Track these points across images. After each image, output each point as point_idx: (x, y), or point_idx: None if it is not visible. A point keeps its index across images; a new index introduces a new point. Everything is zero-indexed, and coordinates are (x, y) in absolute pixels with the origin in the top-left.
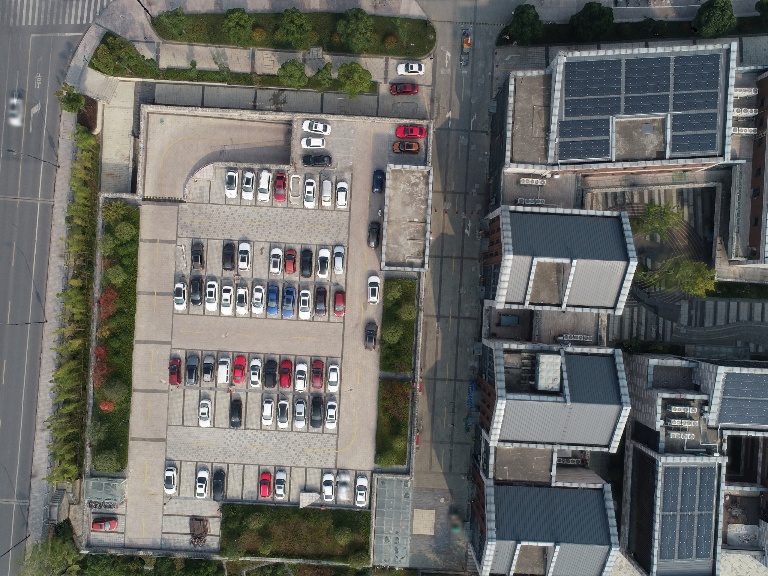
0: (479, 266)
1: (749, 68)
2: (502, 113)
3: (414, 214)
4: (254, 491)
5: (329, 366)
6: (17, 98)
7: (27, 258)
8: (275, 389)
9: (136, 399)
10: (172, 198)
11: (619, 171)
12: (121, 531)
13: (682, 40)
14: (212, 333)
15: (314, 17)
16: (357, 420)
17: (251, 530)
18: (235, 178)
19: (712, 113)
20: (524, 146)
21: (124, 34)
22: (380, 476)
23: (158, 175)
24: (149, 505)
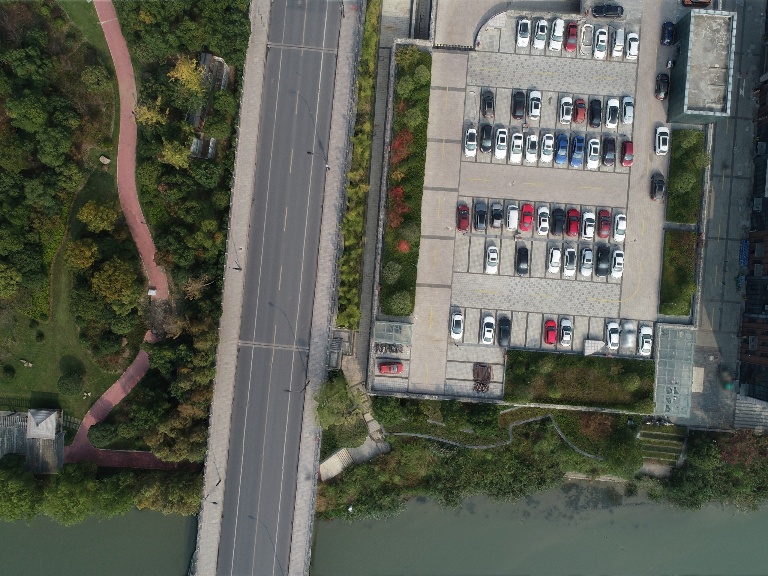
0: (753, 126)
1: None
2: None
3: (715, 60)
4: (537, 339)
5: (616, 215)
6: None
7: (310, 107)
8: (560, 238)
9: (422, 245)
10: (462, 46)
11: None
12: (405, 376)
13: None
14: (499, 181)
15: None
16: (641, 270)
17: (541, 374)
18: (529, 26)
19: None
20: None
21: None
22: (665, 325)
23: (448, 23)
24: (433, 351)
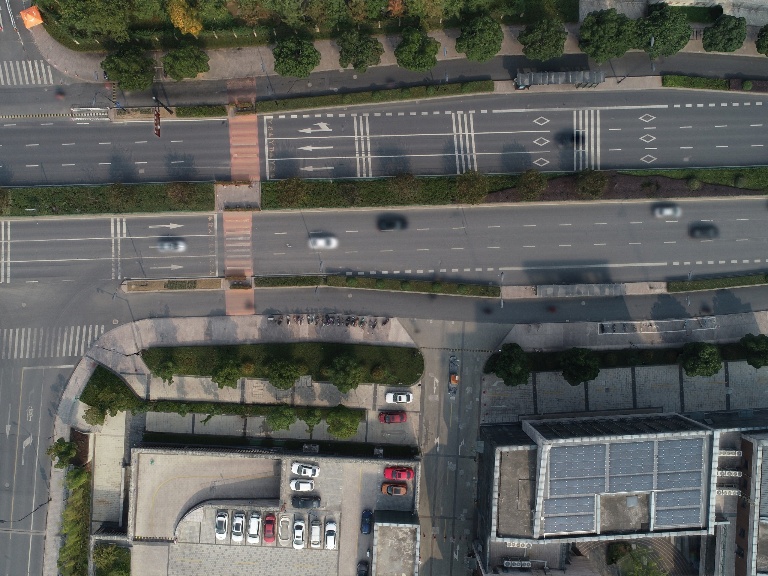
0: None
1: (733, 430)
2: (488, 471)
3: (402, 569)
4: None
5: None
6: (9, 431)
7: None
8: None
9: None
10: (163, 538)
11: None
12: None
13: (668, 365)
14: None
15: (303, 348)
16: None
17: None
18: (225, 522)
19: (696, 490)
20: (510, 519)
21: (115, 367)
22: None
23: (149, 515)
24: None
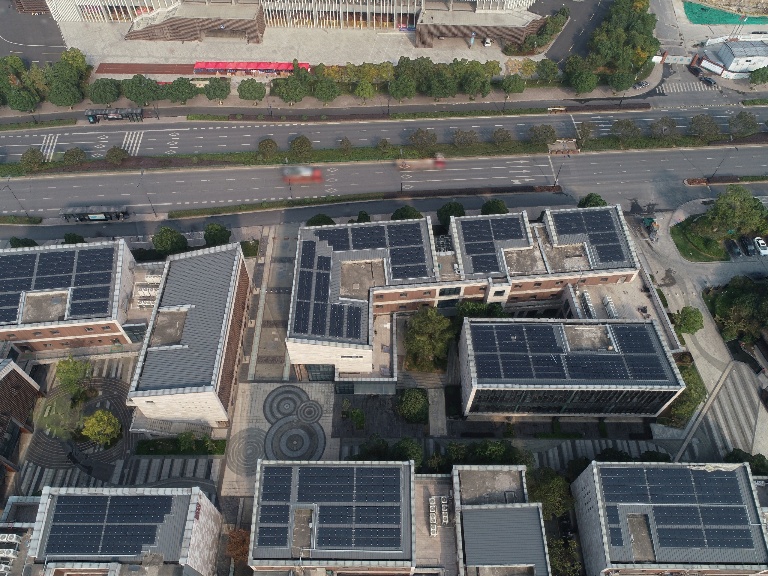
0: None
1: (162, 263)
2: None
3: None
4: None
5: None
6: None
7: None
8: None
9: None
10: None
11: (45, 339)
12: None
13: (160, 261)
14: None
15: None
16: None
17: None
18: None
19: (106, 286)
20: None
21: None
22: None
23: None
24: None
